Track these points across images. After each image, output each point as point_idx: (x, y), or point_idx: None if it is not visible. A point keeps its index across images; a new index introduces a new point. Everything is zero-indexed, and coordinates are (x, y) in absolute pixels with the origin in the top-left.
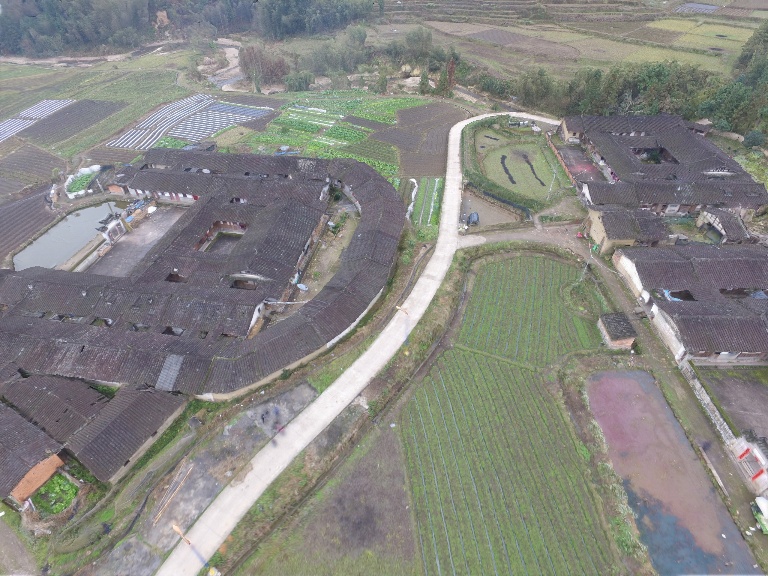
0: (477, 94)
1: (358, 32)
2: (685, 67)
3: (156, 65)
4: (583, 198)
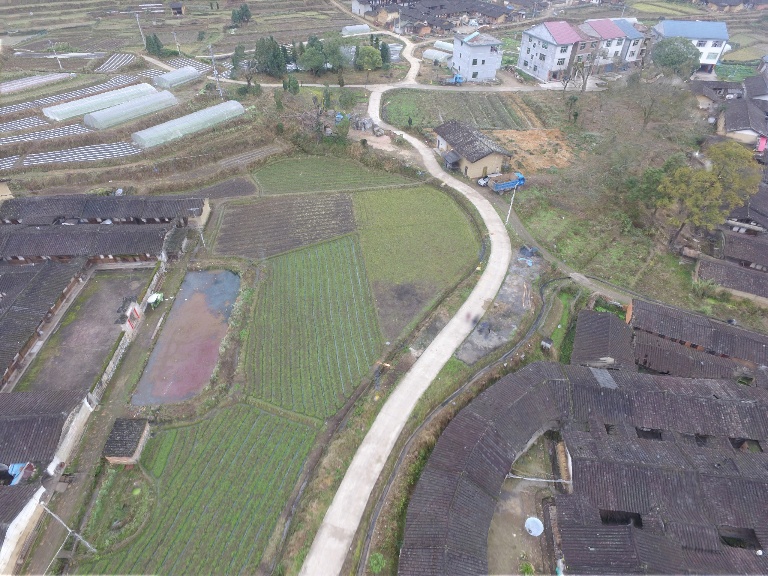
0: None
1: None
2: None
3: None
4: None
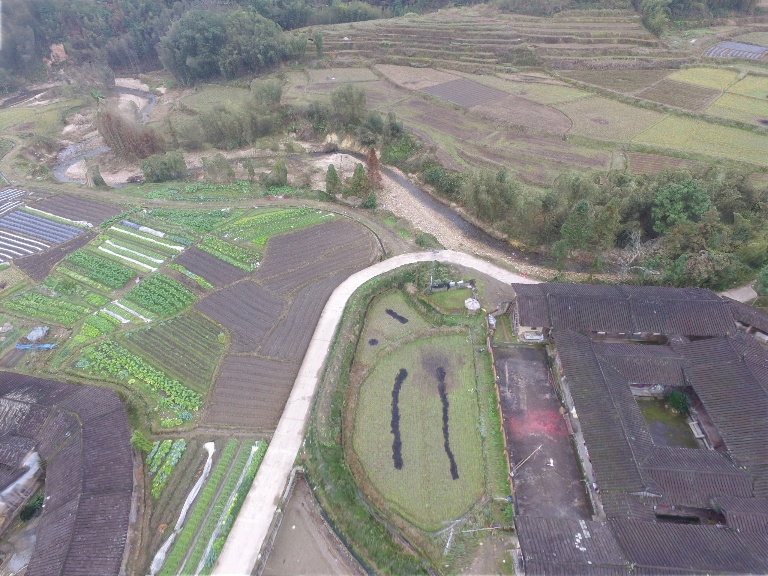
0: (418, 188)
1: (268, 88)
2: (729, 174)
3: (9, 125)
4: (517, 574)
